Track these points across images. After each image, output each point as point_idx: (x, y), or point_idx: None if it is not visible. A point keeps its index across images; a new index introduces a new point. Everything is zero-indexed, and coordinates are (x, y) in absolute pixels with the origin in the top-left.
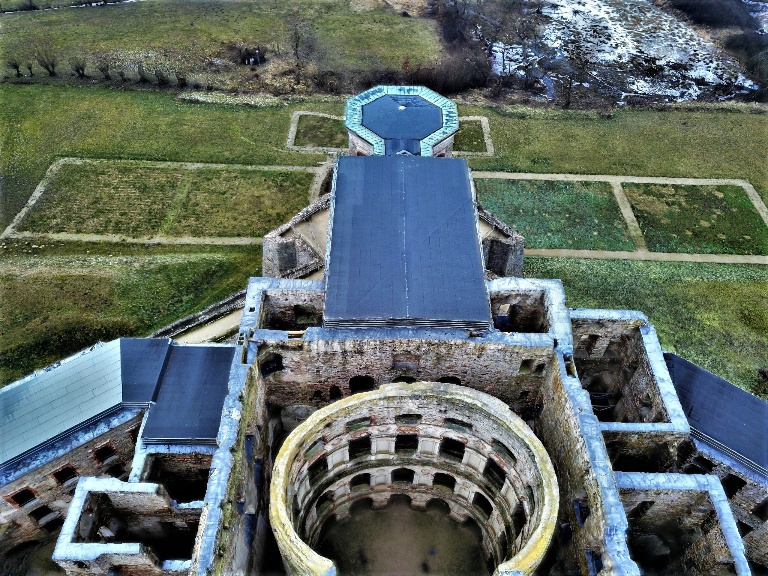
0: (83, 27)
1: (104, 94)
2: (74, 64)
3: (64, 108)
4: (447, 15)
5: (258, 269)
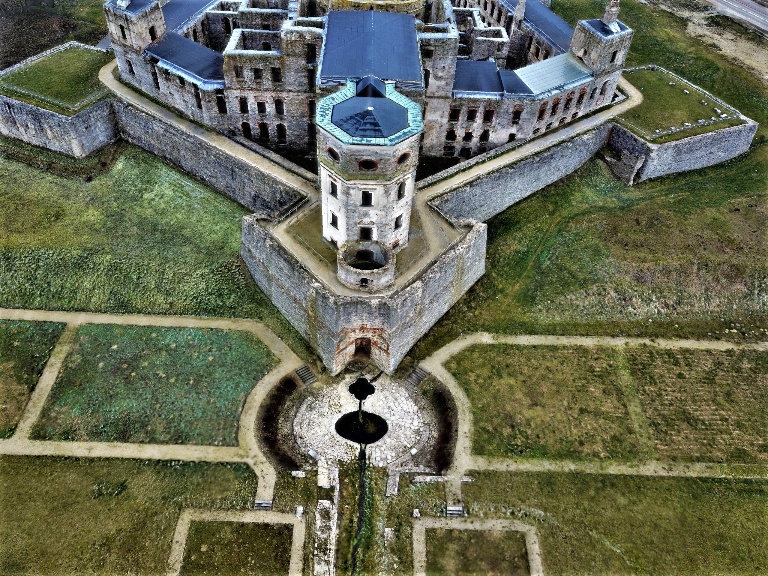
0: None
1: None
2: None
3: None
4: None
5: (496, 298)
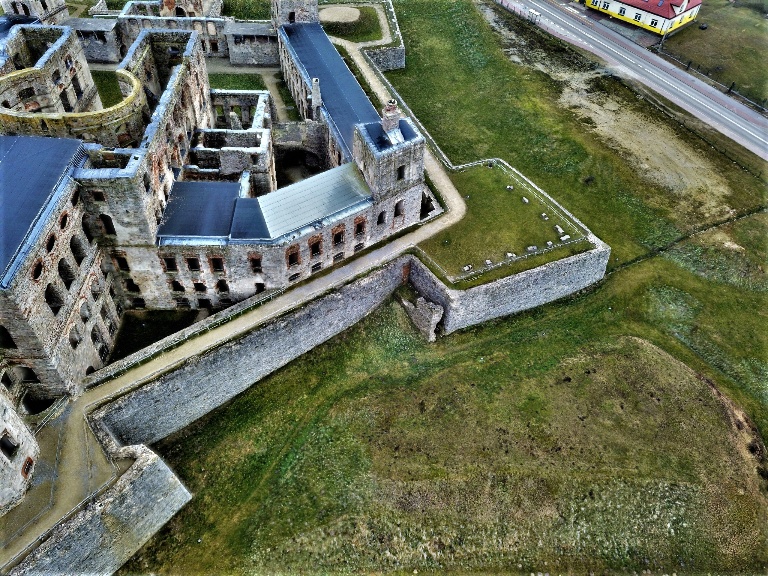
0: None
1: None
2: None
3: None
4: None
5: (198, 541)
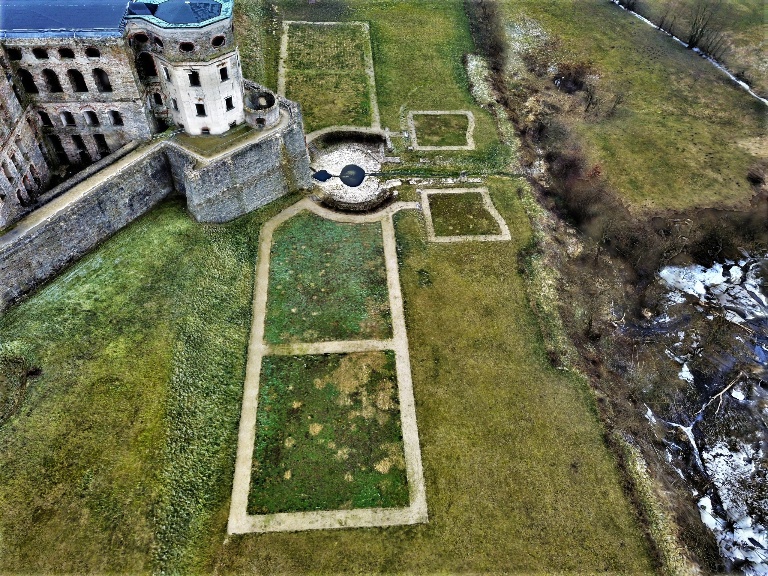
0: (567, 2)
1: (458, 24)
2: (484, 2)
3: (430, 13)
4: (764, 207)
5: None
